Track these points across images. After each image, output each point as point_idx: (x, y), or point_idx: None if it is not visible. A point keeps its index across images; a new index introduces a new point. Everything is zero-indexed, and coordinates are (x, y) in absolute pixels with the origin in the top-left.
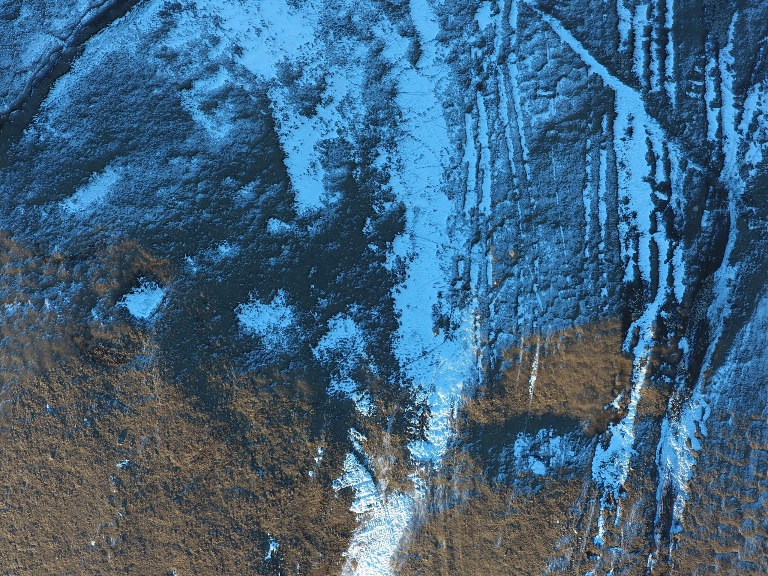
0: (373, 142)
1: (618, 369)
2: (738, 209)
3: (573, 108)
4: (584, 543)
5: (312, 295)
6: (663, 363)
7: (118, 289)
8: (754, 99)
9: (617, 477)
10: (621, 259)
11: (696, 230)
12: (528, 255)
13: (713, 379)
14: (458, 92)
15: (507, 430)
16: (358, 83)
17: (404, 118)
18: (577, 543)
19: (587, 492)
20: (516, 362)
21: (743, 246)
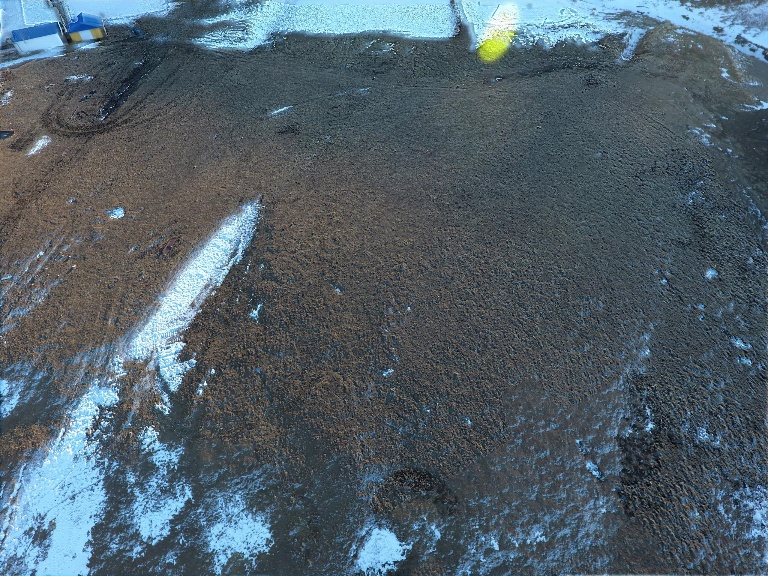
0: None
1: None
2: None
3: None
4: None
5: (182, 568)
6: None
7: (412, 567)
8: None
9: None
10: None
11: None
12: None
13: None
14: None
15: (17, 419)
16: None
17: None
18: None
19: None
20: None
21: None
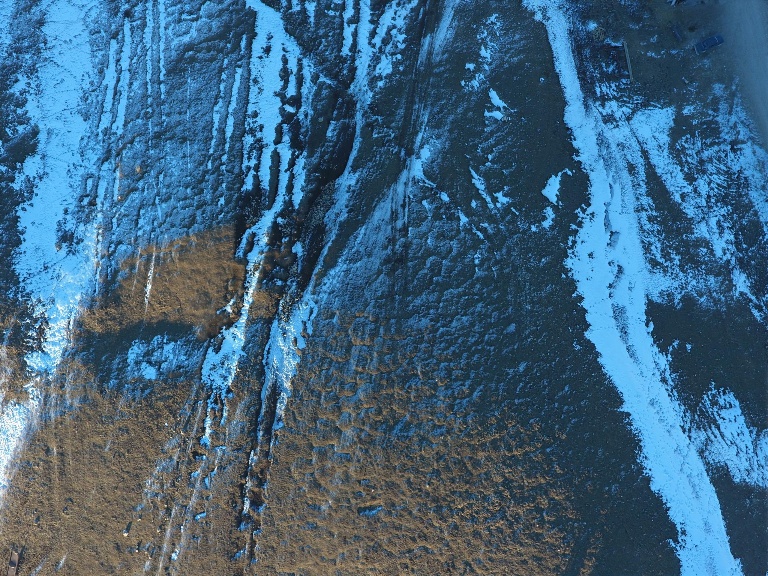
0: (14, 69)
1: (231, 274)
2: (364, 118)
3: (213, 29)
4: (190, 443)
5: None
6: (276, 267)
7: None
8: (390, 14)
9: (225, 378)
10: (242, 169)
11: (320, 140)
12: (154, 170)
13: (323, 280)
14: (106, 19)
15: (122, 338)
16: (7, 14)
17: (49, 45)
18: (184, 444)
19: (195, 394)
20: (132, 272)
21: (365, 153)
